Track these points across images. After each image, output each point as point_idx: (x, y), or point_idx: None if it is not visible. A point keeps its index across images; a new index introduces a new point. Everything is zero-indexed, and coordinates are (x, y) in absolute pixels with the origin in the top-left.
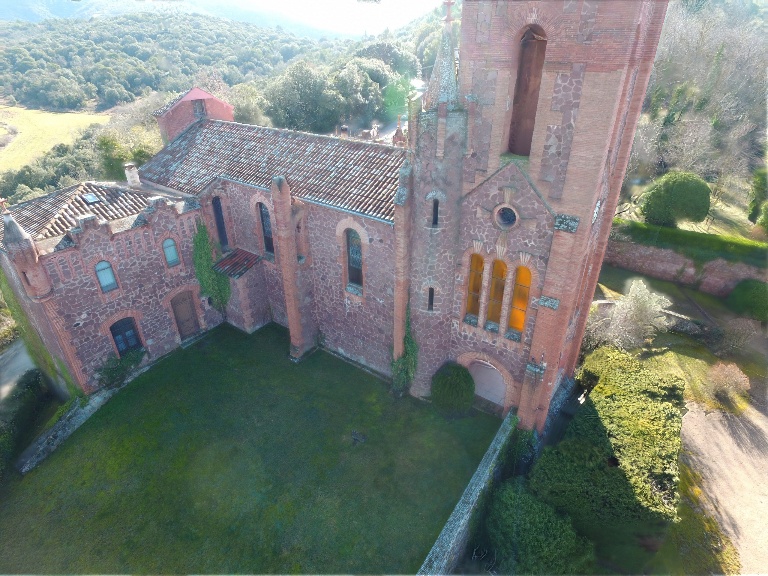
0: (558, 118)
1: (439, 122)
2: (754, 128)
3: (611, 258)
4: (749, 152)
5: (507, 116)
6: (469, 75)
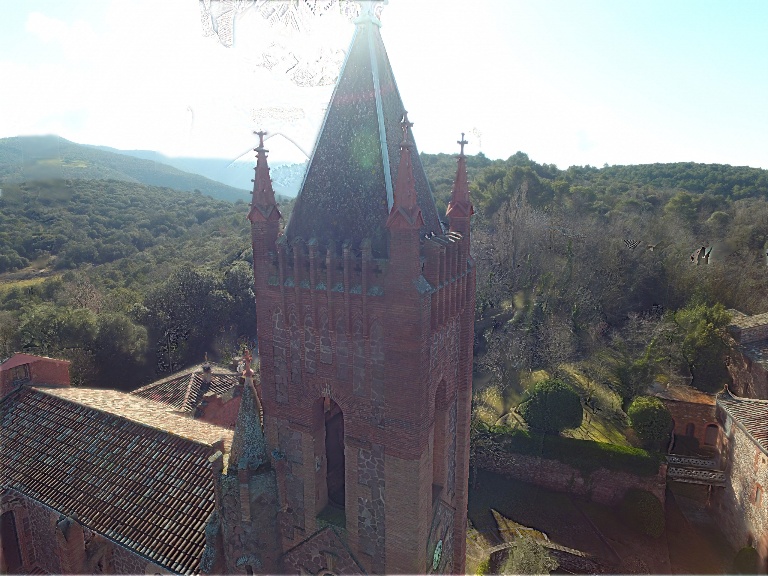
0: (367, 493)
1: (241, 487)
2: (606, 326)
3: (503, 469)
4: (606, 354)
5: (319, 474)
6: (274, 430)
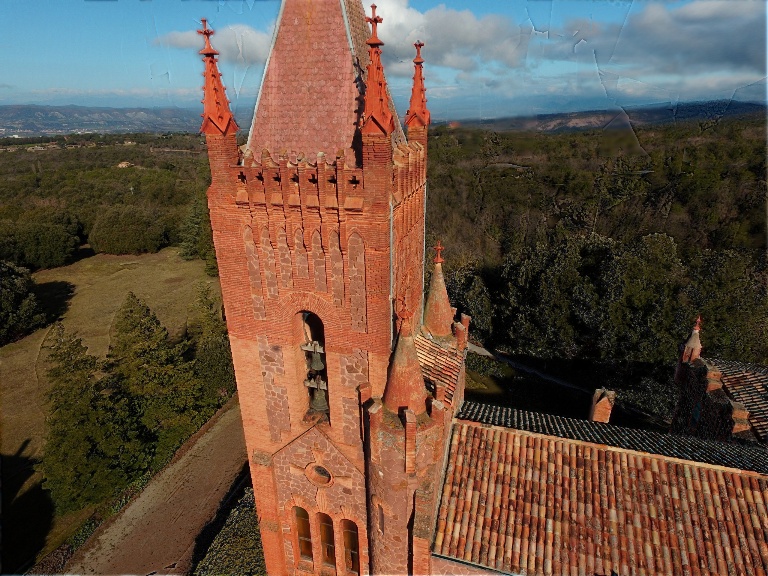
0: None
1: None
2: None
3: None
4: None
5: None
6: None
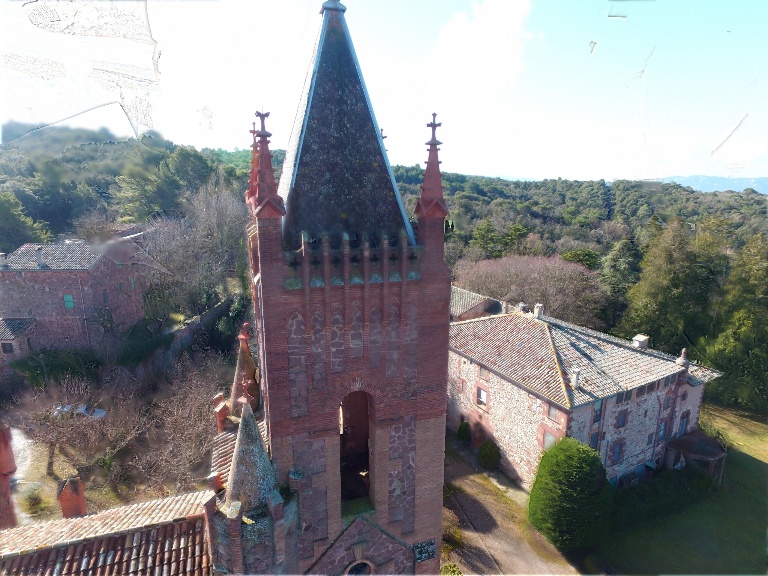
0: (398, 464)
1: (276, 527)
2: None
3: None
4: None
5: None
6: (288, 451)
